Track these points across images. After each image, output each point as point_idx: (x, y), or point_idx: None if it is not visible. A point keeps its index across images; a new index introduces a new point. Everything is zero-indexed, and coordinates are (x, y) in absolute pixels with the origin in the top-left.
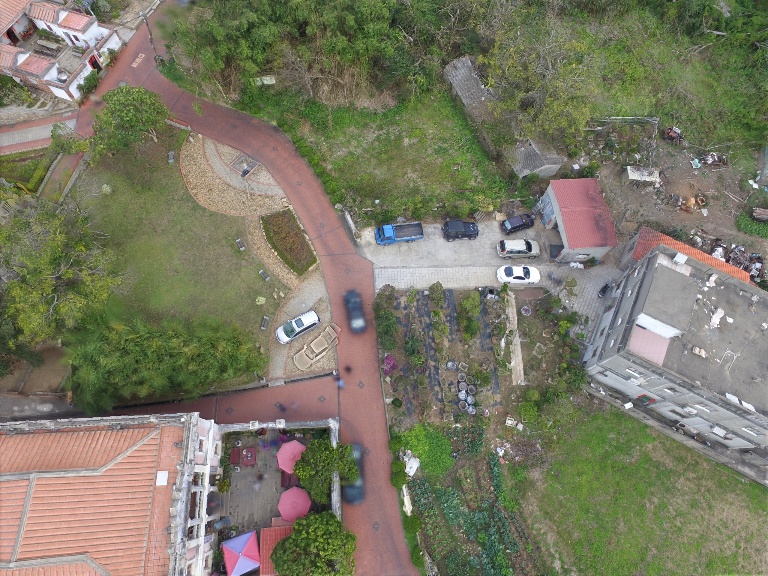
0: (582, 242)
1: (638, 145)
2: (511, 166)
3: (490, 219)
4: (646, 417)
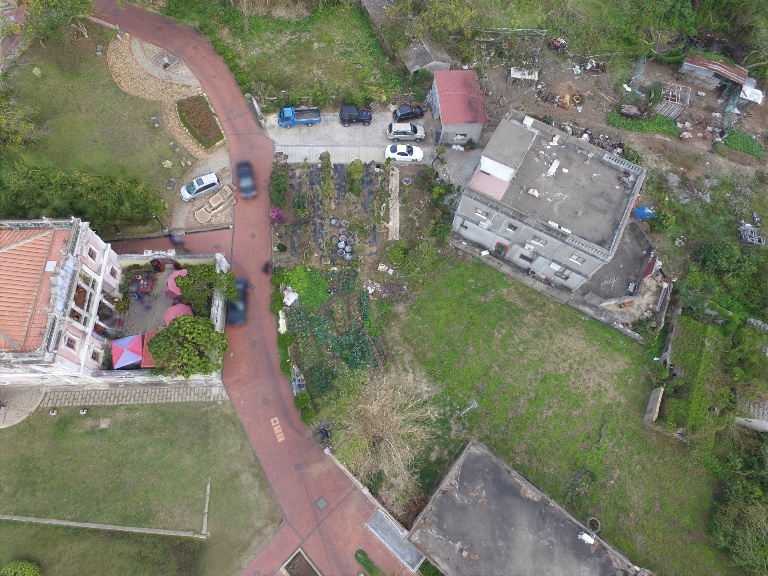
0: (455, 119)
1: (526, 54)
2: (405, 63)
3: (385, 110)
4: (500, 263)
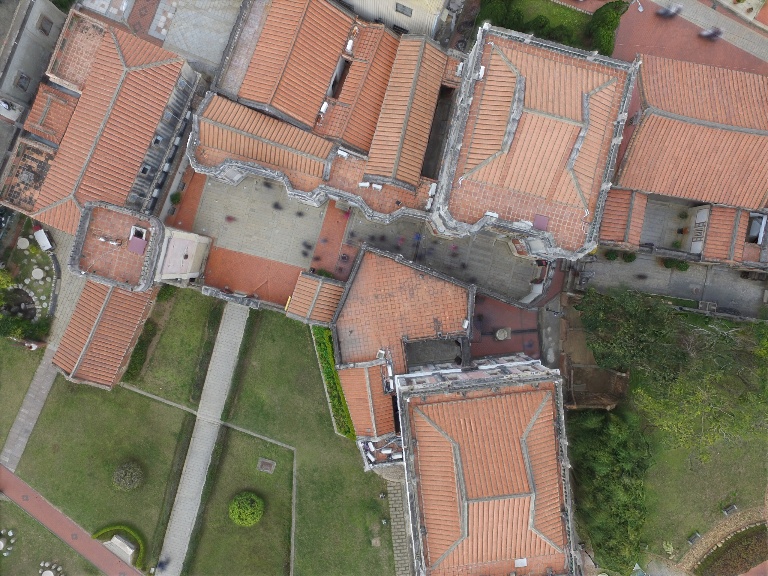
0: None
1: None
2: None
3: None
4: None
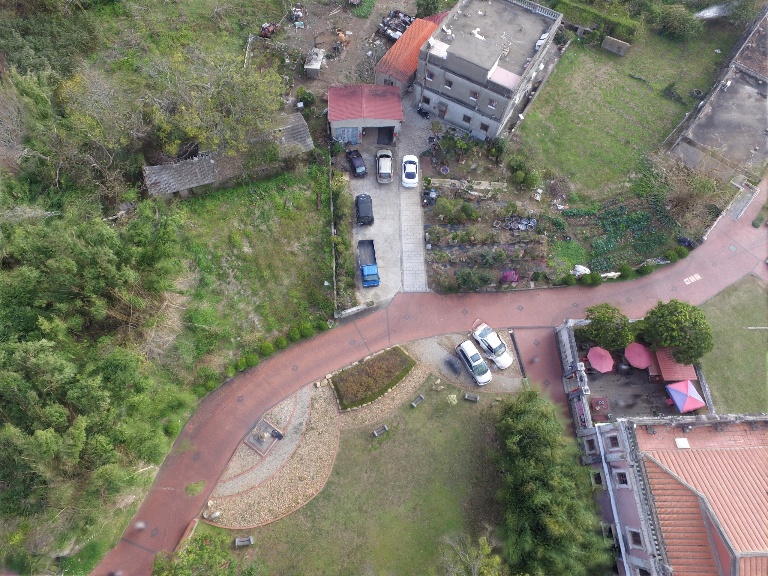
0: (396, 110)
1: None
2: None
3: (348, 186)
4: None
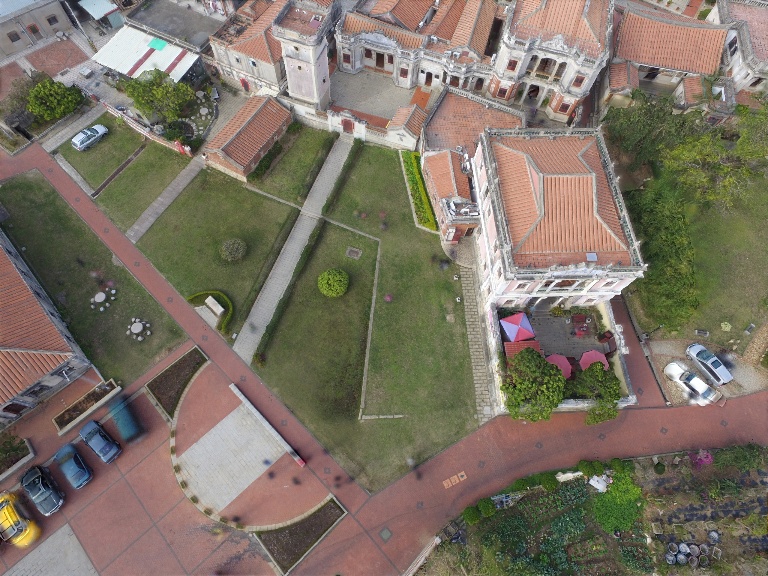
0: None
1: None
2: None
3: None
4: None
